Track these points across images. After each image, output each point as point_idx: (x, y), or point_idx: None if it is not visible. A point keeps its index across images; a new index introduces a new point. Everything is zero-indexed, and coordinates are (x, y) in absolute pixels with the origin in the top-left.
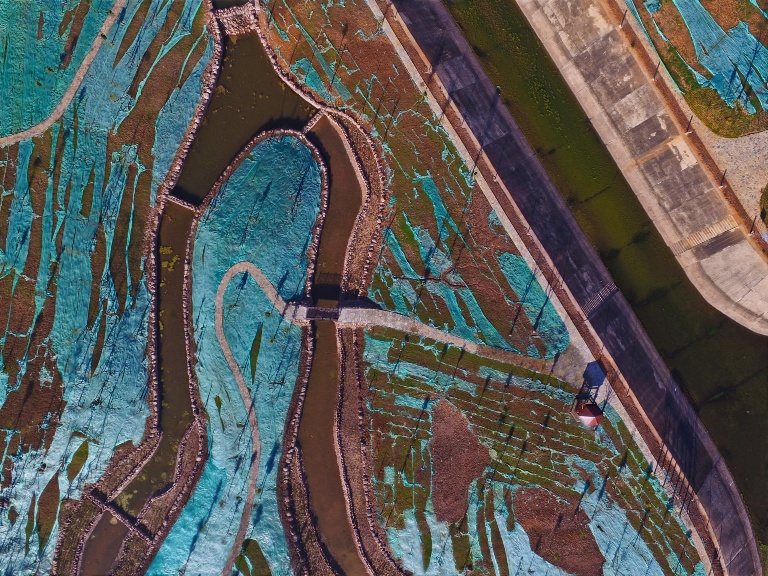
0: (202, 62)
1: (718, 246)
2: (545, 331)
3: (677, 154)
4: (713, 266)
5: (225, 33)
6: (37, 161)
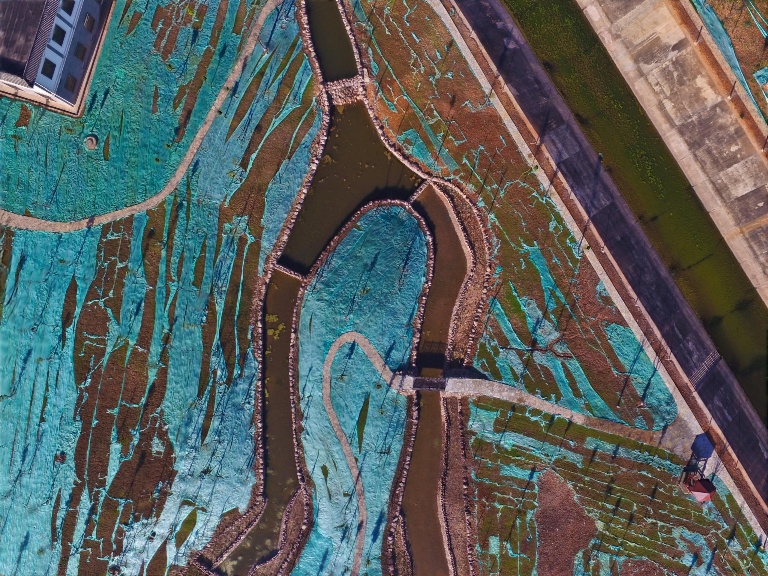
0: (310, 133)
1: None
2: (653, 402)
3: None
4: None
5: (332, 103)
6: (151, 233)
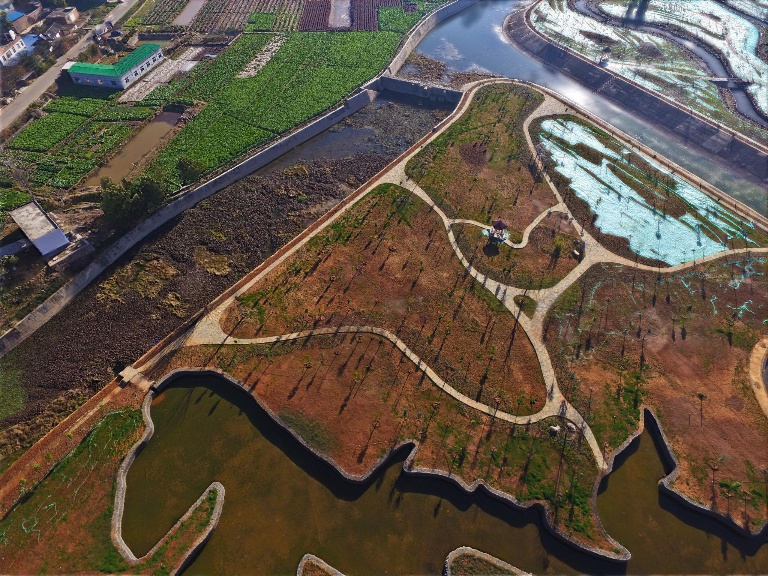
0: None
1: None
2: None
3: None
4: None
5: None
6: None
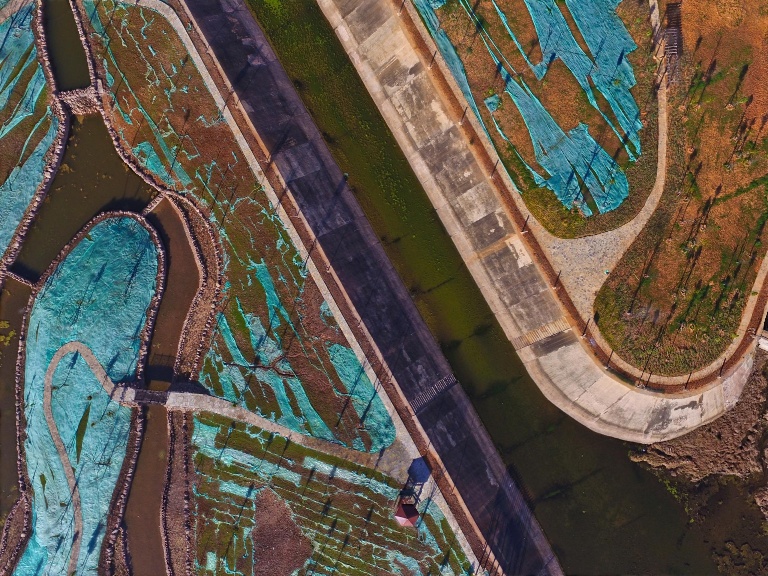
0: (45, 141)
1: (554, 345)
2: (372, 425)
3: (514, 252)
4: (550, 364)
5: (71, 113)
6: None
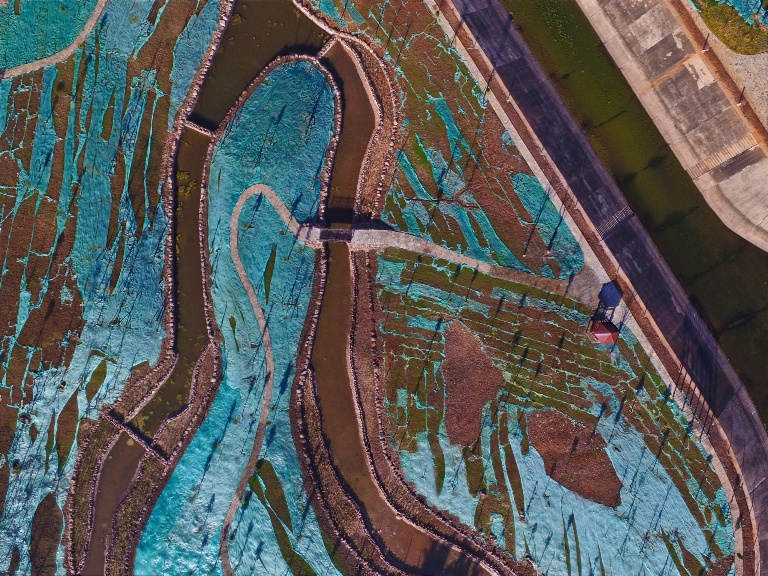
0: None
1: (737, 167)
2: (559, 252)
3: (693, 73)
4: (732, 188)
5: None
6: (60, 86)
